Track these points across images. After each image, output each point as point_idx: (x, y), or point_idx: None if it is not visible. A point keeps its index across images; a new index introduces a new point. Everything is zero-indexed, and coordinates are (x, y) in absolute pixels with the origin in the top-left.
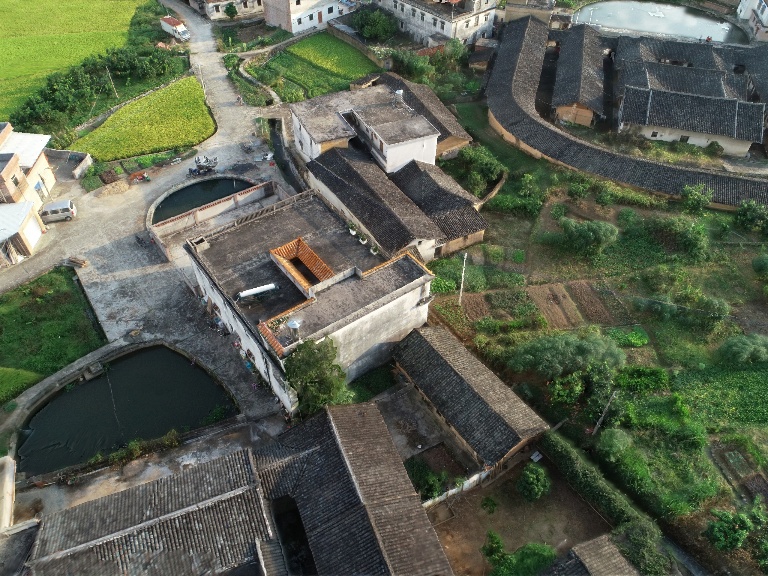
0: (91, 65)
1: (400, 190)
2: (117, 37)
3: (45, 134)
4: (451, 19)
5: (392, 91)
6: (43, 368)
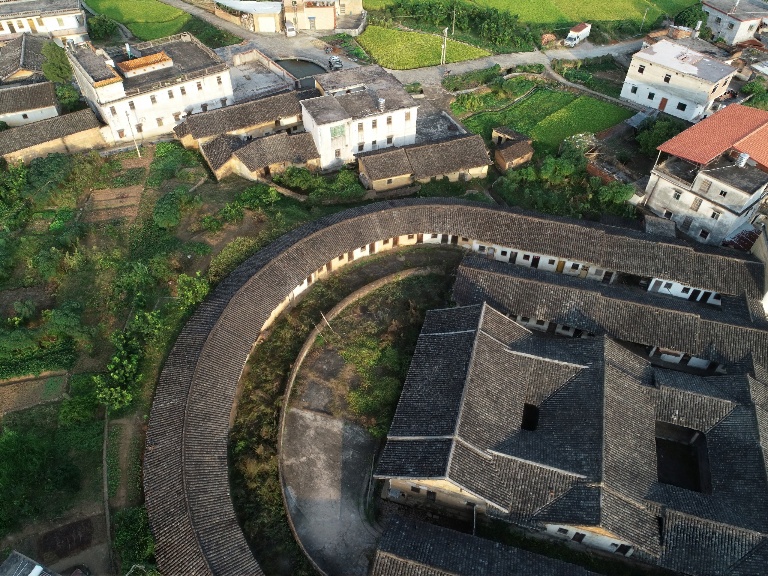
0: (485, 13)
1: (261, 122)
2: (554, 18)
3: None
4: (655, 168)
5: (405, 108)
6: None
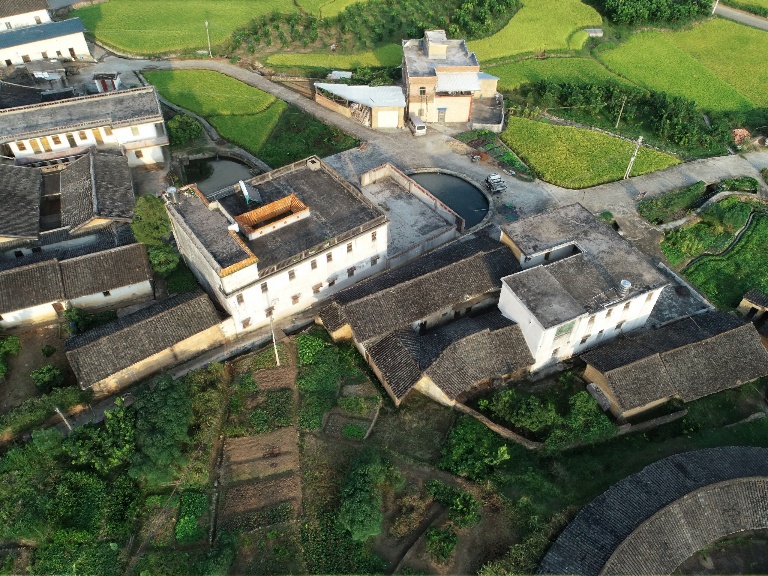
0: (652, 98)
1: (445, 306)
2: (735, 104)
3: (533, 104)
4: None
5: (652, 288)
6: (261, 152)
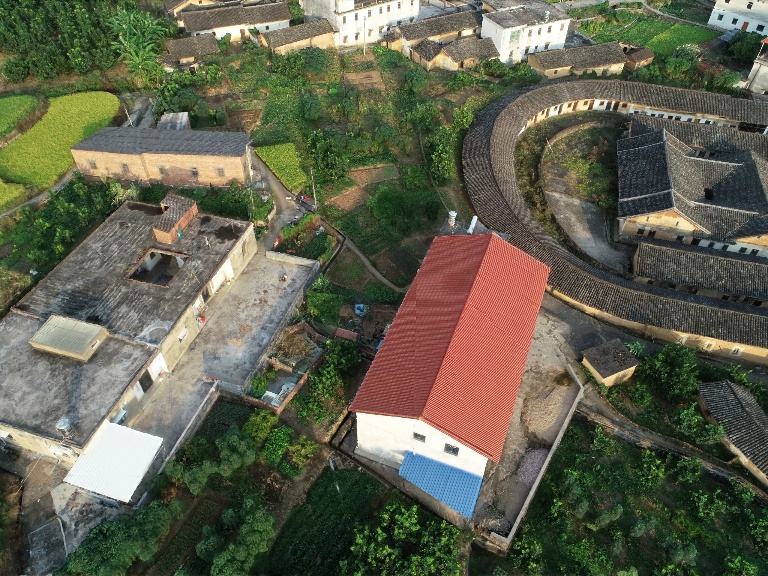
0: None
1: (452, 31)
2: None
3: None
4: (757, 58)
5: (562, 19)
6: None
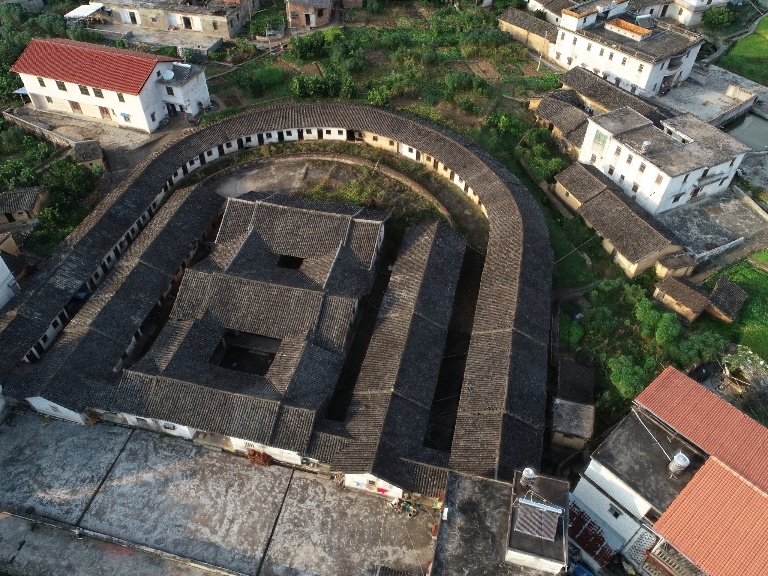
0: None
1: (601, 104)
2: None
3: None
4: None
5: (659, 167)
6: None
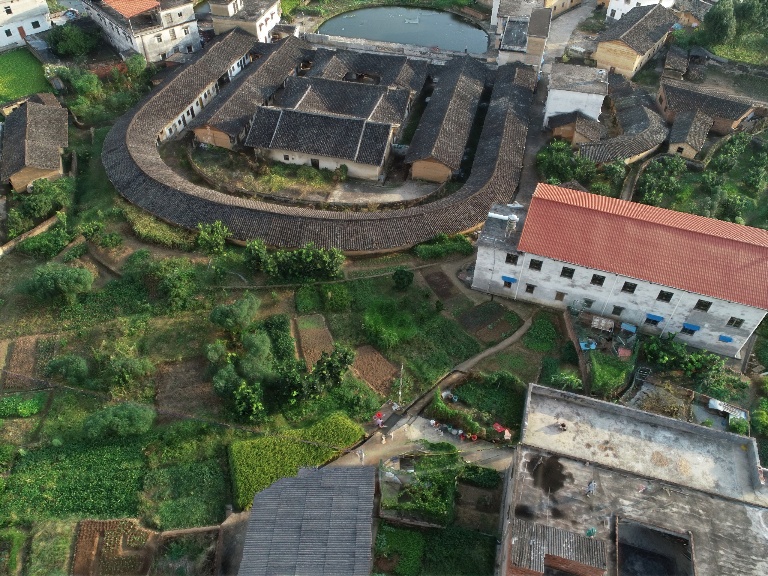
0: None
1: None
2: None
3: None
4: (133, 34)
5: None
6: None
